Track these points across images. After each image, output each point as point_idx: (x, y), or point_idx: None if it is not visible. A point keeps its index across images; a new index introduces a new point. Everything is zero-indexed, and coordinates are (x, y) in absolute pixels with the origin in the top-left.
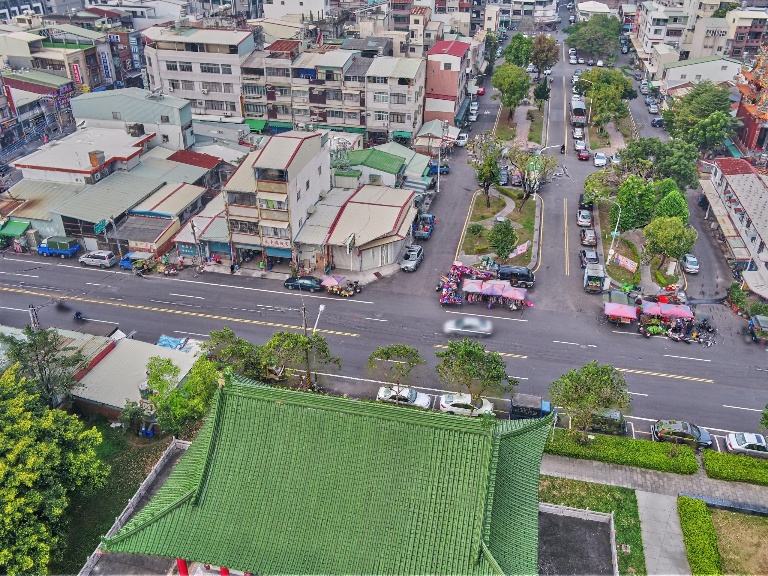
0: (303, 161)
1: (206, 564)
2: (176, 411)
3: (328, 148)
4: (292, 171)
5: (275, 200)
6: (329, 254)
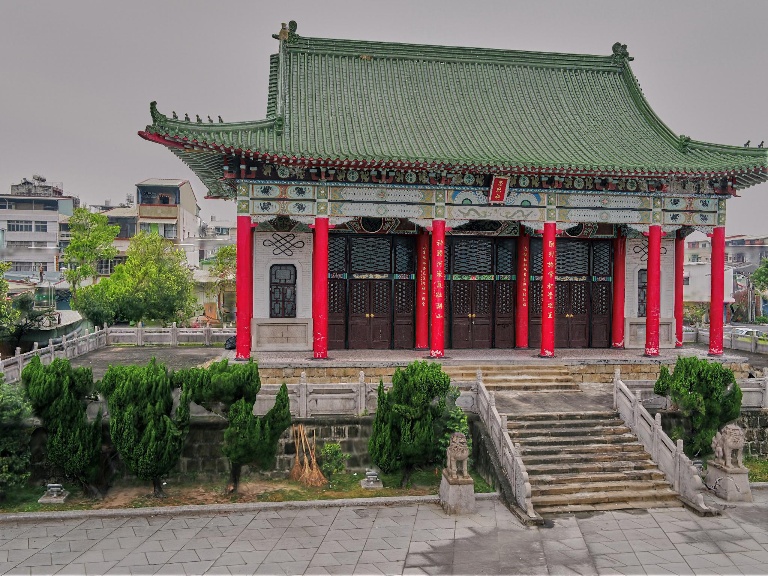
0: (187, 204)
1: None
2: (108, 292)
3: (198, 227)
4: (181, 198)
5: (163, 223)
6: (220, 302)
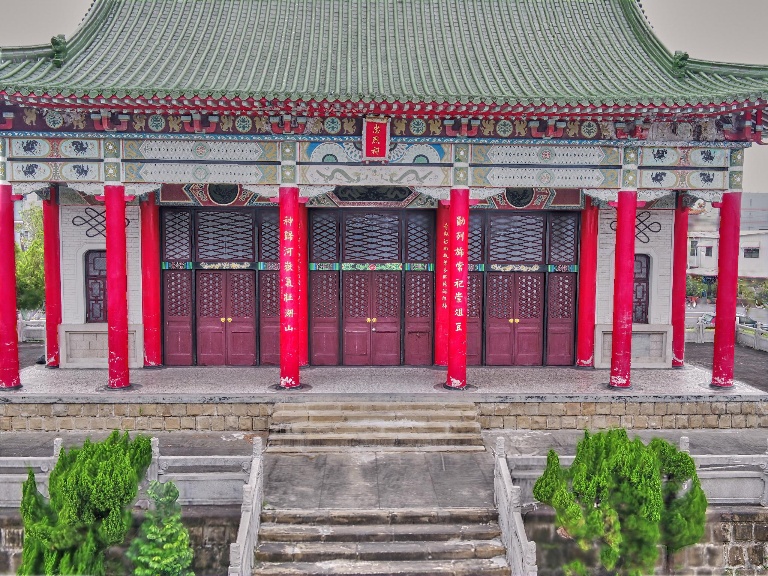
0: None
1: (51, 351)
2: None
3: None
4: None
5: None
6: None
